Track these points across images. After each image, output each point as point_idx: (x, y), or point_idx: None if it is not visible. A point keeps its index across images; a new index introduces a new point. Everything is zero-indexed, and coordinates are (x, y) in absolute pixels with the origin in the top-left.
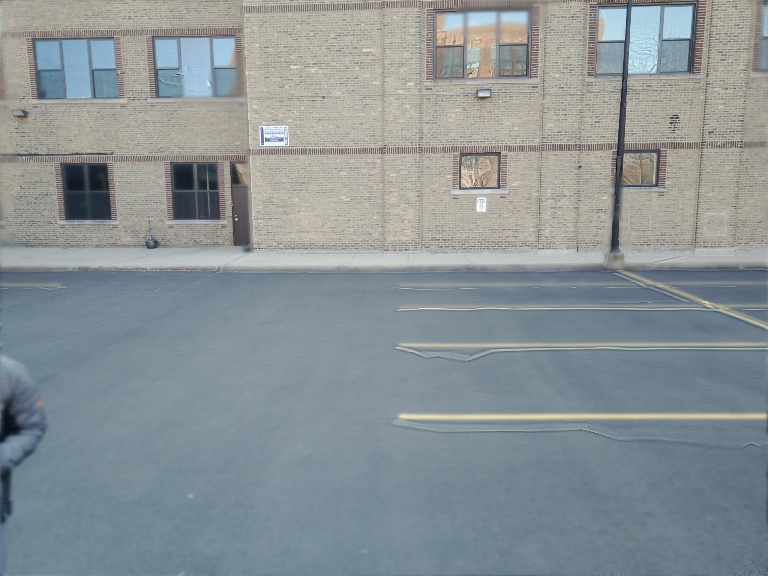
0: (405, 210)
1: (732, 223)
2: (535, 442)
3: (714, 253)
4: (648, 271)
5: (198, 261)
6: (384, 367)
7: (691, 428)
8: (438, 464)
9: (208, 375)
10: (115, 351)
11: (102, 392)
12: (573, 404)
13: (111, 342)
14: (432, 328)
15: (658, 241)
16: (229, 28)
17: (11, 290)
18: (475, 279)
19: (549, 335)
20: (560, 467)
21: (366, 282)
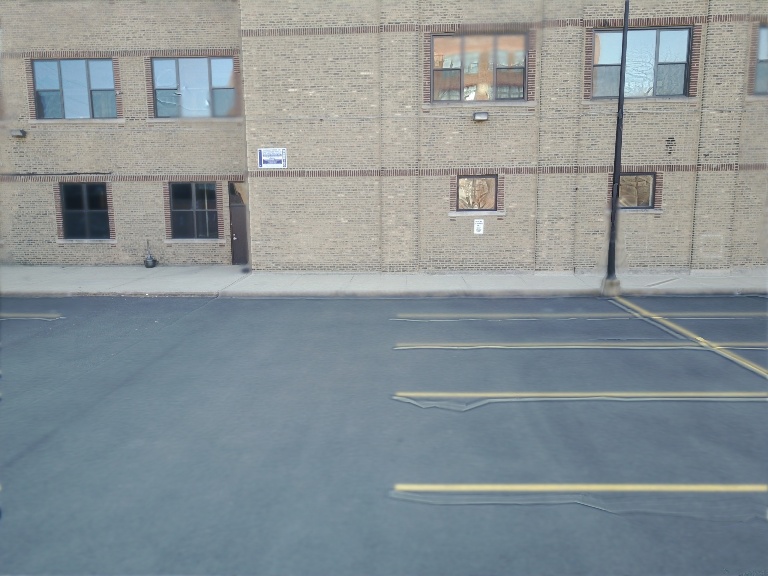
0: (403, 232)
1: (728, 245)
2: (529, 520)
3: (710, 274)
4: (644, 298)
5: (197, 284)
6: (381, 423)
7: (683, 499)
8: (434, 547)
9: (207, 432)
10: (115, 401)
11: (102, 454)
12: (567, 471)
13: (111, 390)
14: (429, 371)
15: (654, 262)
16: (227, 49)
17: (10, 322)
18: (472, 308)
19: (545, 381)
20: (553, 552)
21: (364, 311)
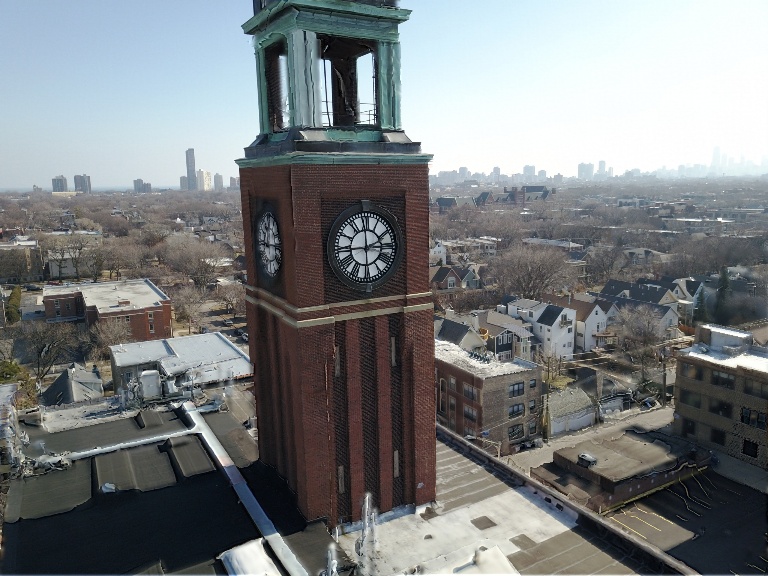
0: None
1: None
2: None
3: None
4: None
5: None
6: None
7: None
8: None
9: None
10: None
11: None
12: None
13: (749, 521)
14: None
15: None
16: None
17: None
18: None
19: None
20: None
21: None
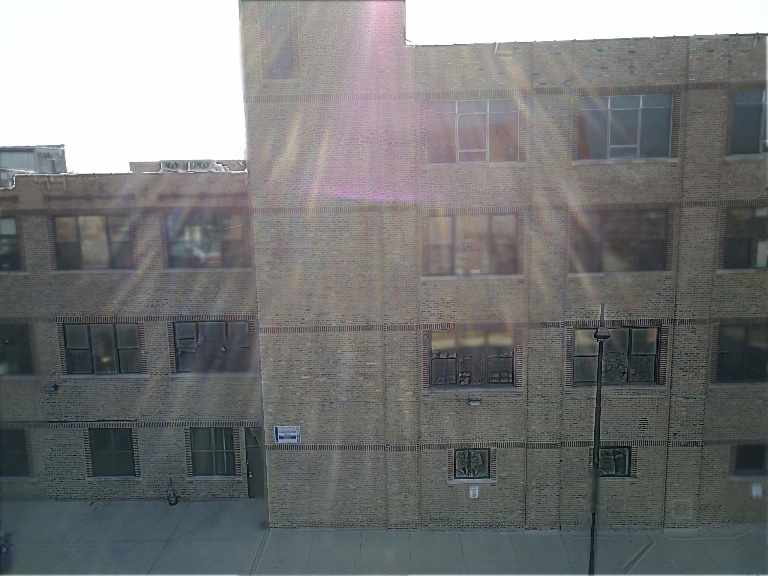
0: (406, 497)
1: (696, 508)
2: None
3: (681, 533)
4: None
5: (223, 568)
6: None
7: None
8: None
9: None
10: None
11: None
12: None
13: None
14: None
15: (631, 521)
16: (243, 315)
17: None
18: None
19: None
20: None
21: None
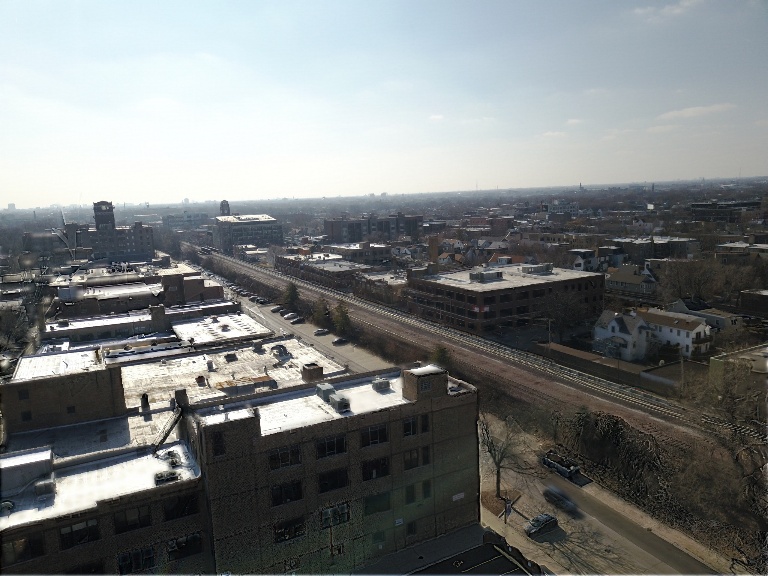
0: None
1: (364, 557)
2: None
3: (360, 567)
4: None
5: None
6: None
7: None
8: None
9: None
10: None
11: None
12: None
13: None
14: None
15: (345, 568)
16: (197, 531)
17: None
18: None
19: None
20: None
21: None
